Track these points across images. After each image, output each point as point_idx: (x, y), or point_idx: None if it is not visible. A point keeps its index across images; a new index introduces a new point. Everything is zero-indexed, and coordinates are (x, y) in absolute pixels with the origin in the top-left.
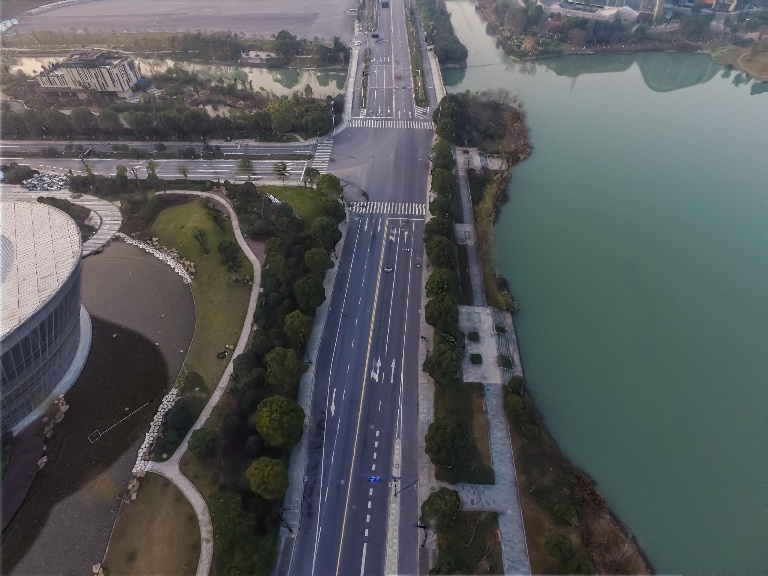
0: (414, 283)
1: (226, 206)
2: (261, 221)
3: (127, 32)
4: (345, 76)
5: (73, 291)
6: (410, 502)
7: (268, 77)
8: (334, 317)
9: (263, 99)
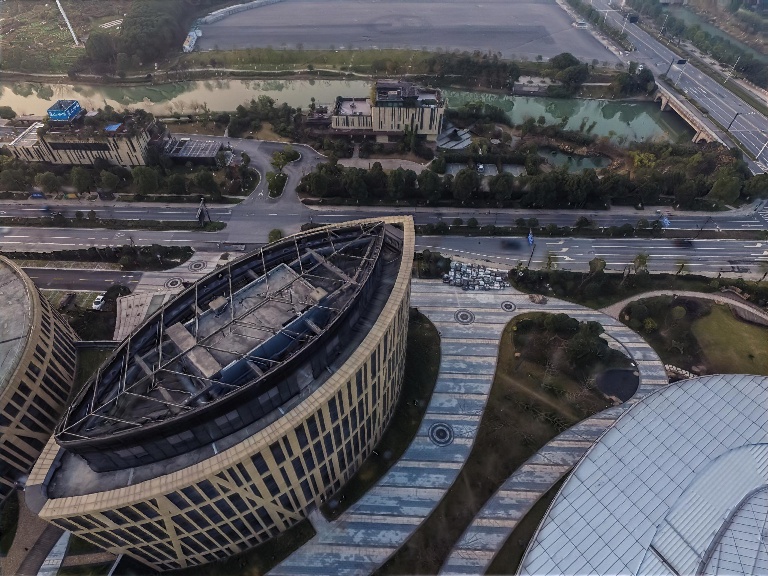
0: None
1: (765, 318)
2: None
3: (347, 49)
4: (635, 107)
5: None
6: None
7: (536, 106)
8: None
9: (606, 144)
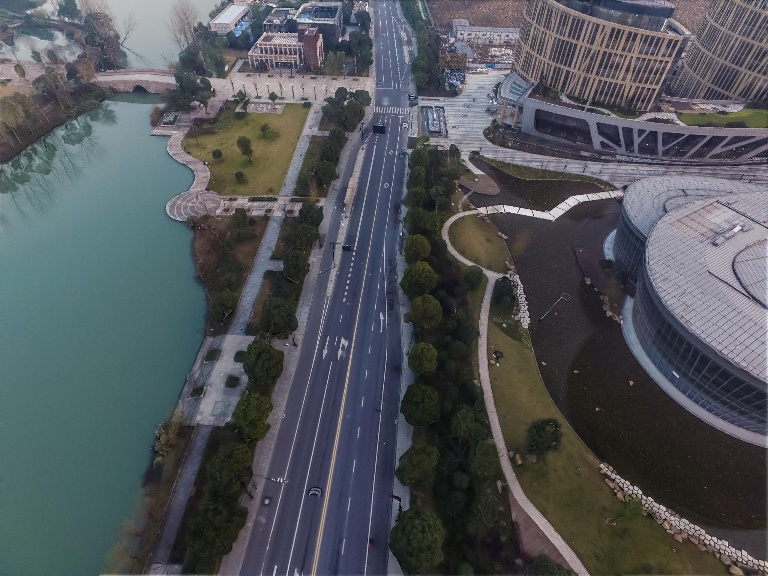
0: (281, 463)
1: None
2: (546, 570)
3: None
4: None
5: (659, 315)
6: (325, 265)
7: None
8: (390, 409)
9: None
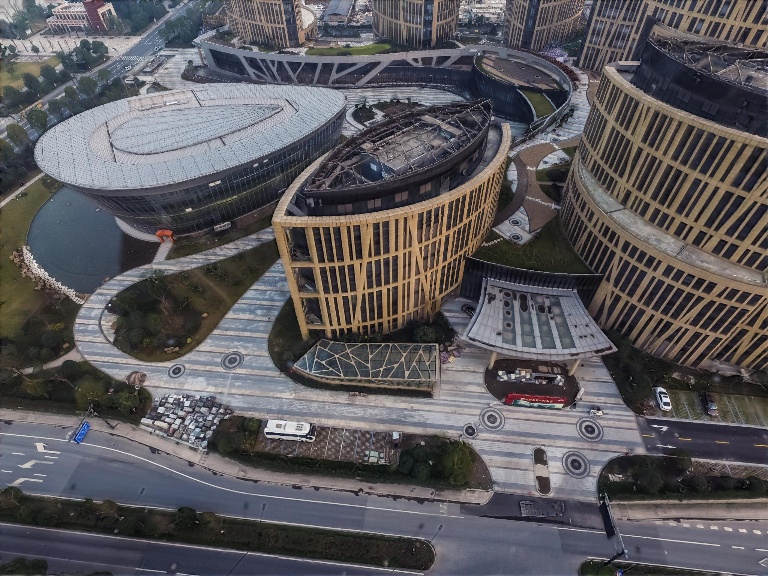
0: None
1: None
2: None
3: None
4: None
5: None
6: None
7: None
8: None
9: None
